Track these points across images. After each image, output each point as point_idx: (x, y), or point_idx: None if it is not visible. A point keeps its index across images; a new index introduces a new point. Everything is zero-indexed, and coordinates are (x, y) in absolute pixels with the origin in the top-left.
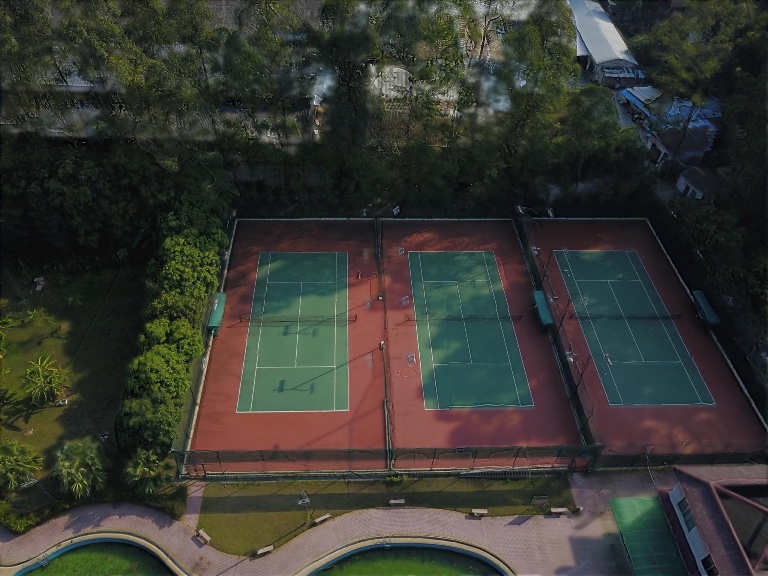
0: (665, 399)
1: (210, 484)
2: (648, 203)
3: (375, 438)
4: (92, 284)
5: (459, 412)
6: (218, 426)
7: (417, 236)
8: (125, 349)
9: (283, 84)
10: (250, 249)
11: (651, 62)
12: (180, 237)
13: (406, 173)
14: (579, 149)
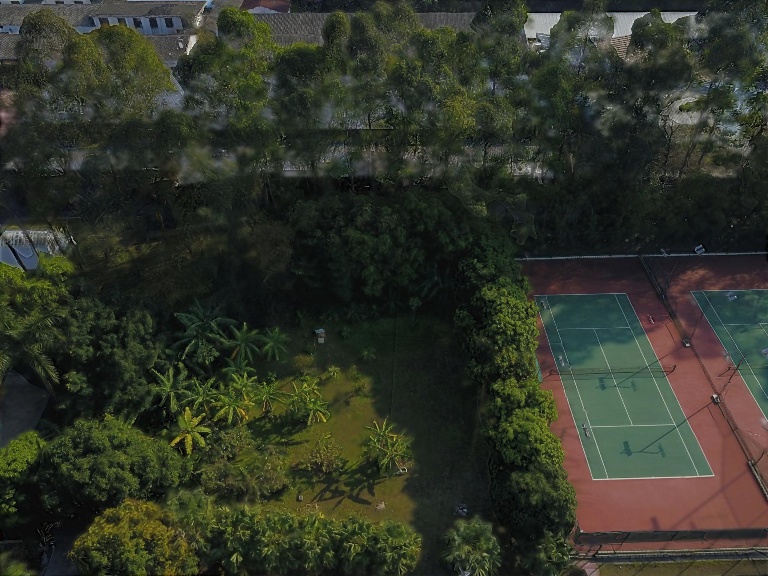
0: None
1: (603, 565)
2: None
3: (758, 508)
4: (374, 335)
5: None
6: (581, 496)
7: (692, 274)
8: (440, 408)
9: (586, 119)
10: None
11: None
12: (496, 287)
13: (677, 207)
14: None
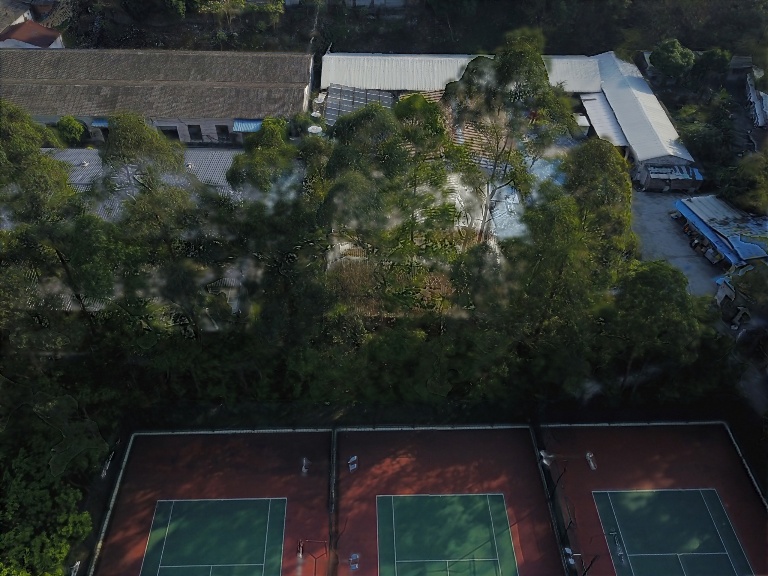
0: None
1: None
2: (727, 402)
3: None
4: None
5: None
6: None
7: (391, 463)
8: None
9: (171, 283)
10: (144, 495)
11: (710, 156)
12: None
13: (375, 371)
14: (630, 344)
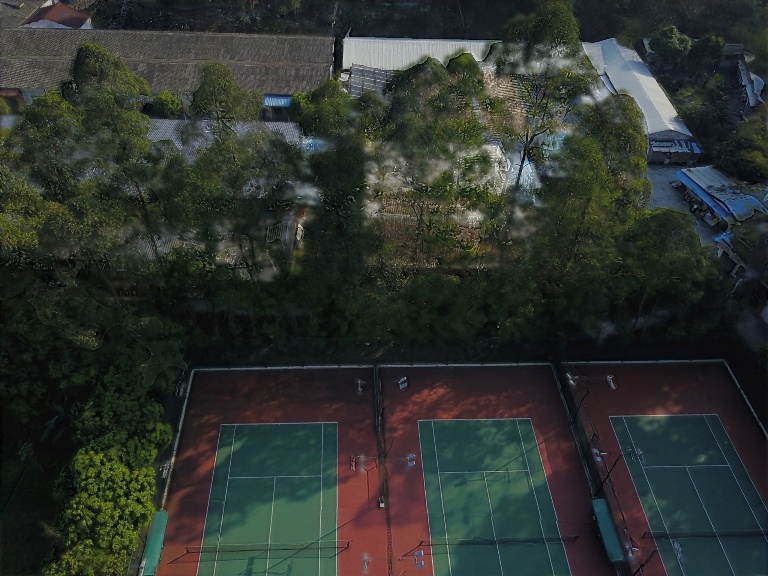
0: None
1: None
2: (727, 341)
3: None
4: None
5: None
6: None
7: (429, 394)
8: None
9: (246, 220)
10: (208, 420)
11: (707, 131)
12: (98, 447)
13: (414, 311)
14: (643, 284)
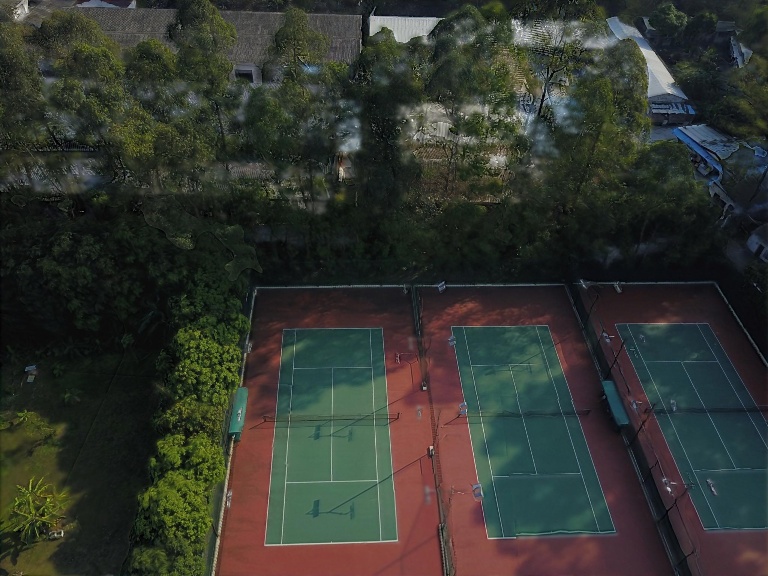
0: (767, 520)
1: None
2: (717, 265)
3: None
4: (92, 373)
5: (528, 542)
6: (244, 565)
7: (460, 307)
8: (131, 459)
9: (312, 145)
10: (272, 325)
11: (701, 96)
12: (195, 328)
13: (447, 235)
14: (645, 210)
